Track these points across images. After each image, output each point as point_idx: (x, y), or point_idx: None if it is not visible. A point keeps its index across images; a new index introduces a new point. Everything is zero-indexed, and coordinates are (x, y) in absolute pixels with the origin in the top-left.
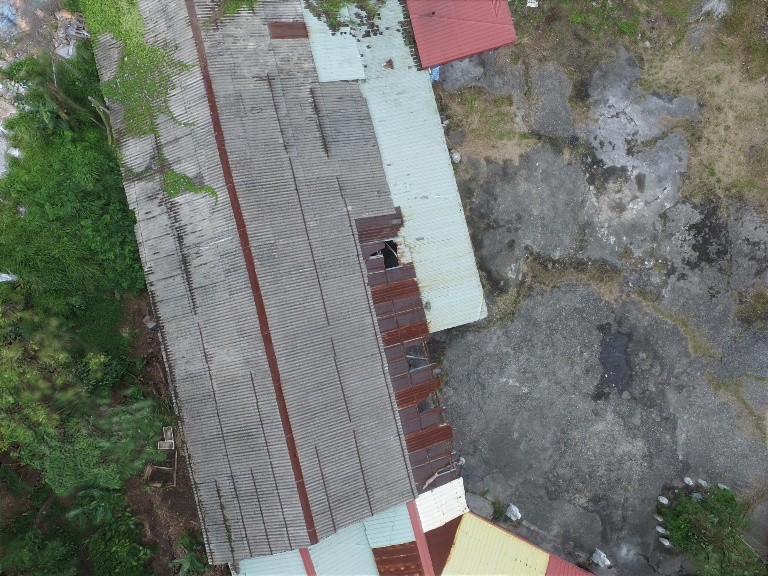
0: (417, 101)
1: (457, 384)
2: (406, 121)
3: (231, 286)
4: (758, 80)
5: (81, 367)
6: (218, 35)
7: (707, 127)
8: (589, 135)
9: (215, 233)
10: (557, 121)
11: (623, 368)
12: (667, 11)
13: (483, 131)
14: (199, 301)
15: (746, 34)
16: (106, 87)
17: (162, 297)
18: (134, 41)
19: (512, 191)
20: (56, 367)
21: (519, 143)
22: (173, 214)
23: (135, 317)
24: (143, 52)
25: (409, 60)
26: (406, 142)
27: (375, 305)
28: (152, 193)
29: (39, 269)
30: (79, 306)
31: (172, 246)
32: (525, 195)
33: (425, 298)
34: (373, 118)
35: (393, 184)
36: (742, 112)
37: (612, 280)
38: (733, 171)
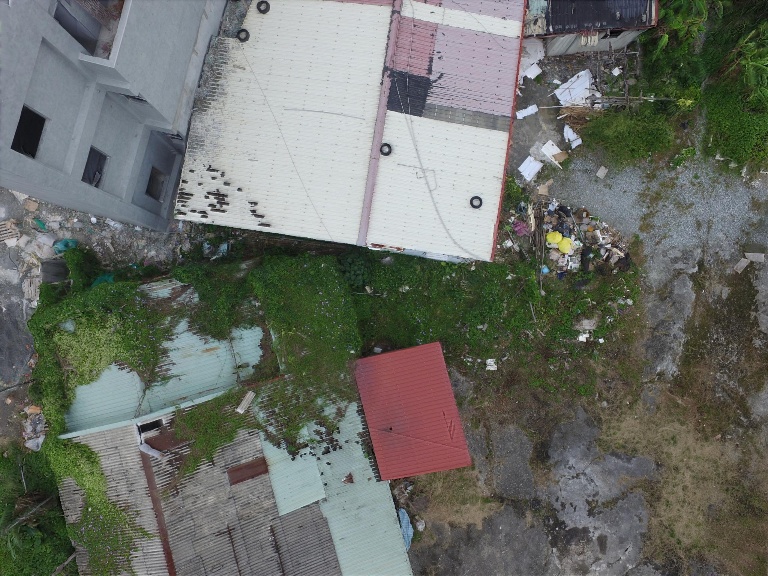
0: (377, 513)
1: None
2: (367, 535)
3: None
4: (714, 438)
5: None
6: (178, 499)
7: (666, 487)
8: (550, 497)
9: None
10: (519, 484)
11: None
12: (623, 372)
13: (446, 497)
14: None
15: (701, 392)
16: (71, 533)
17: None
18: (97, 499)
19: (476, 556)
20: None
21: (482, 507)
22: None
23: None
24: (106, 510)
25: (368, 471)
26: (367, 557)
27: None
28: None
29: None
30: None
31: None
32: (489, 559)
33: None
34: (334, 537)
35: None
36: (700, 471)
37: None
38: (693, 531)
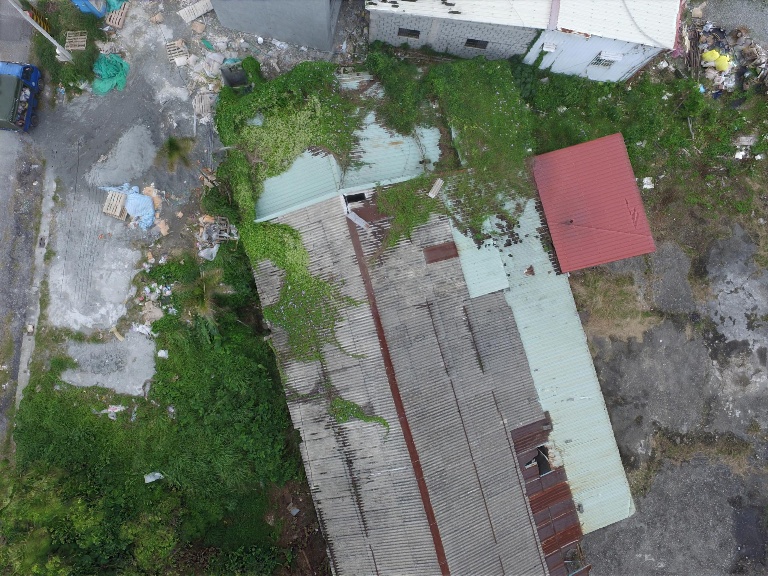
0: (558, 305)
1: (594, 561)
2: (549, 325)
3: (405, 514)
4: None
5: (234, 562)
6: (382, 269)
7: None
8: (710, 311)
9: (387, 462)
10: (678, 298)
11: (755, 540)
12: None
13: (607, 311)
14: (370, 524)
15: None
16: (269, 313)
17: (330, 516)
18: (300, 274)
19: (638, 368)
20: (206, 559)
21: (642, 321)
22: (341, 438)
23: (279, 504)
24: (308, 284)
25: (548, 265)
26: (550, 346)
27: (534, 515)
28: (318, 416)
29: (196, 473)
30: (232, 504)
31: (340, 468)
32: (651, 372)
33: (577, 500)
34: (518, 325)
35: (541, 389)
36: None
37: (739, 453)
38: None
